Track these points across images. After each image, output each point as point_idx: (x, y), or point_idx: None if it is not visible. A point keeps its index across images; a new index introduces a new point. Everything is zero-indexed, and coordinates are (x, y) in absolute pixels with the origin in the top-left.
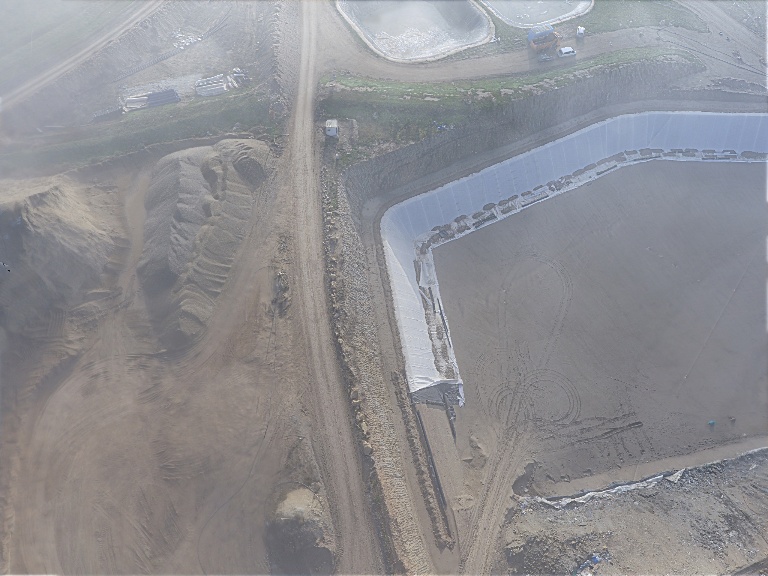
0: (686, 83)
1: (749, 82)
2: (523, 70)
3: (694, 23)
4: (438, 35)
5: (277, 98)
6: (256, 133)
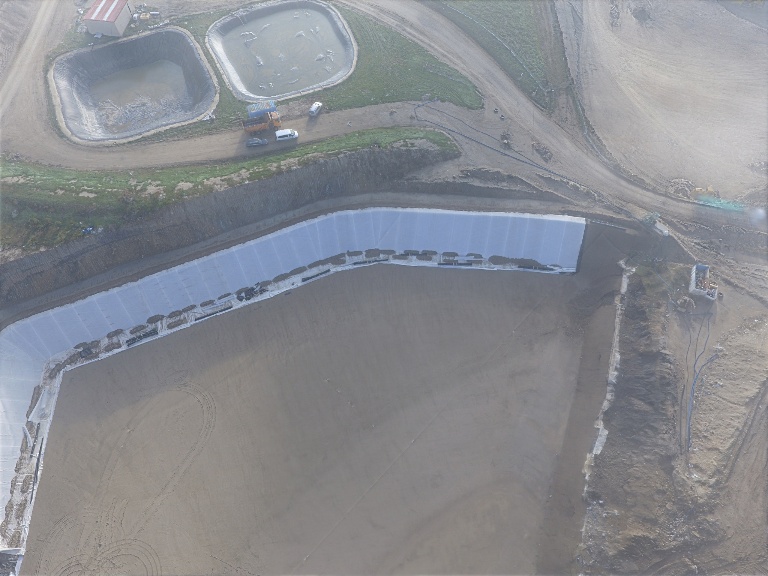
0: (429, 173)
1: (507, 173)
2: (225, 156)
3: (466, 97)
4: (169, 105)
5: None
6: None
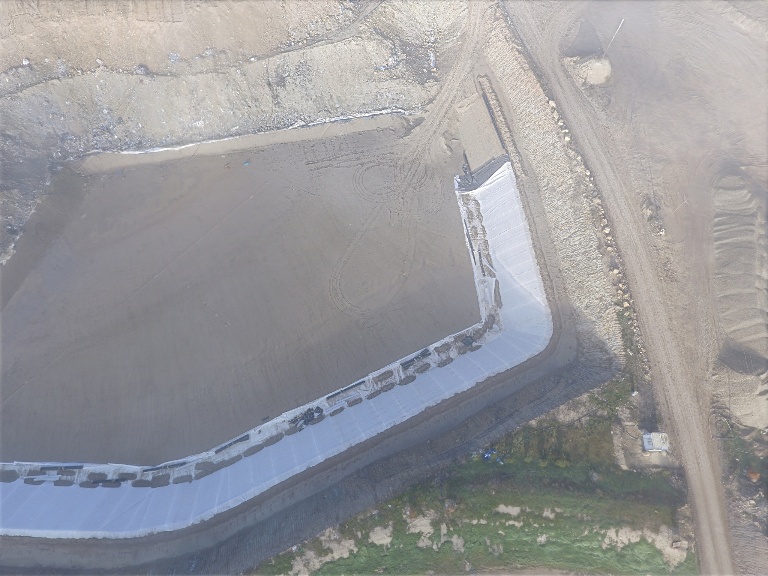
0: None
1: None
2: None
3: None
4: None
5: (759, 507)
6: (761, 441)
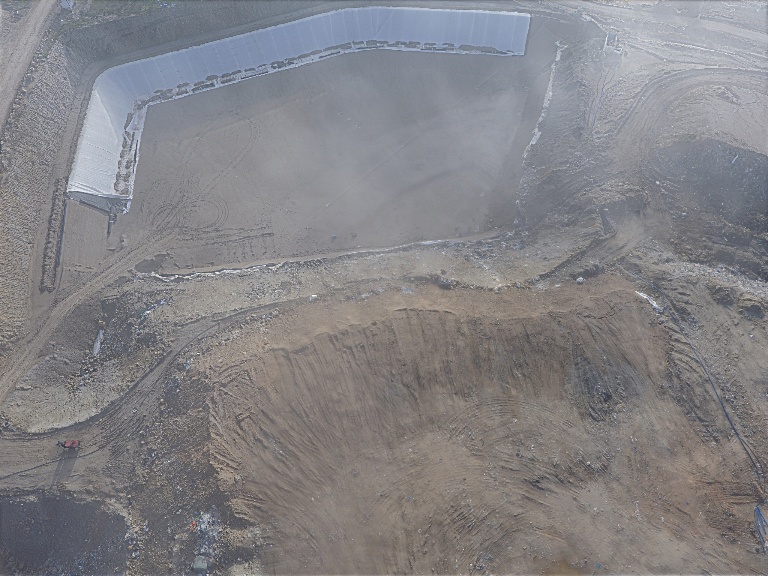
0: None
1: None
2: None
3: None
4: None
5: None
6: (5, 5)
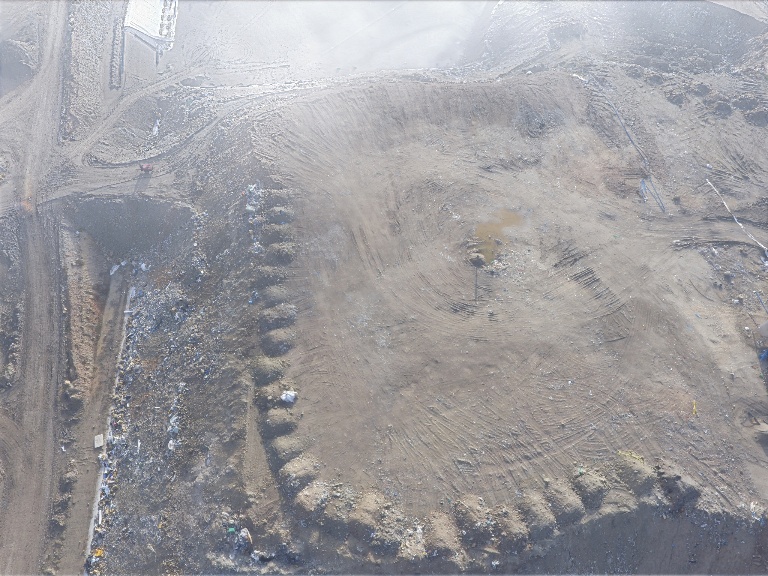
0: None
1: None
2: None
3: None
4: None
5: None
6: None
